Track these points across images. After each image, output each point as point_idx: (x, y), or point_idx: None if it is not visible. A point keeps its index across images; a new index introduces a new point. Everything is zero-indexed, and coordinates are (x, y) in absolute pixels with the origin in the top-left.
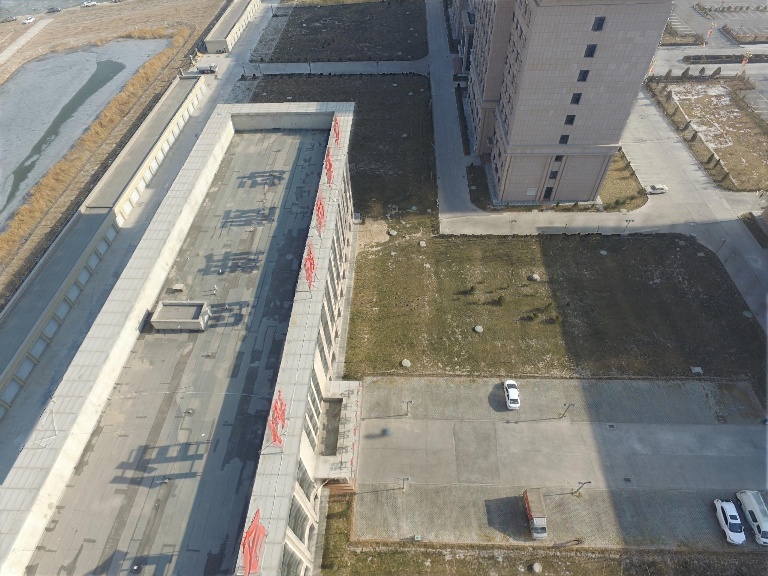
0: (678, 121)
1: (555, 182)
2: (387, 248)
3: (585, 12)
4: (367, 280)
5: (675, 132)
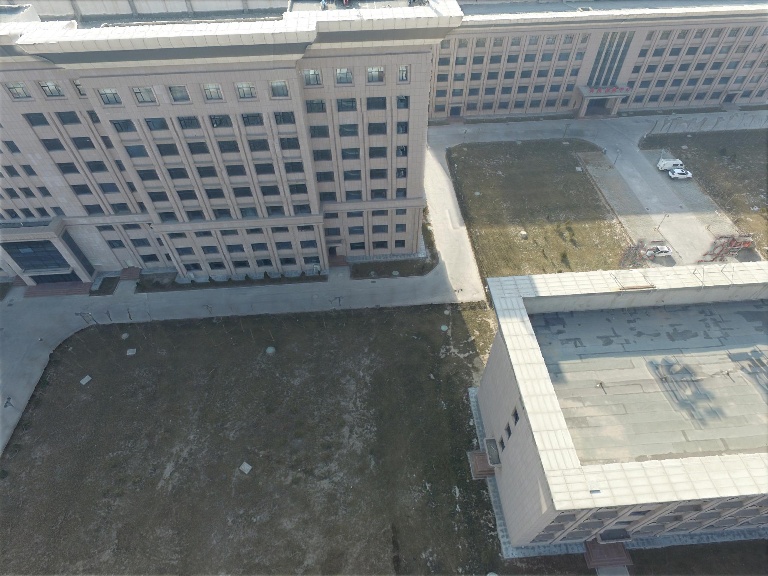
0: None
1: None
2: None
3: None
4: None
5: None
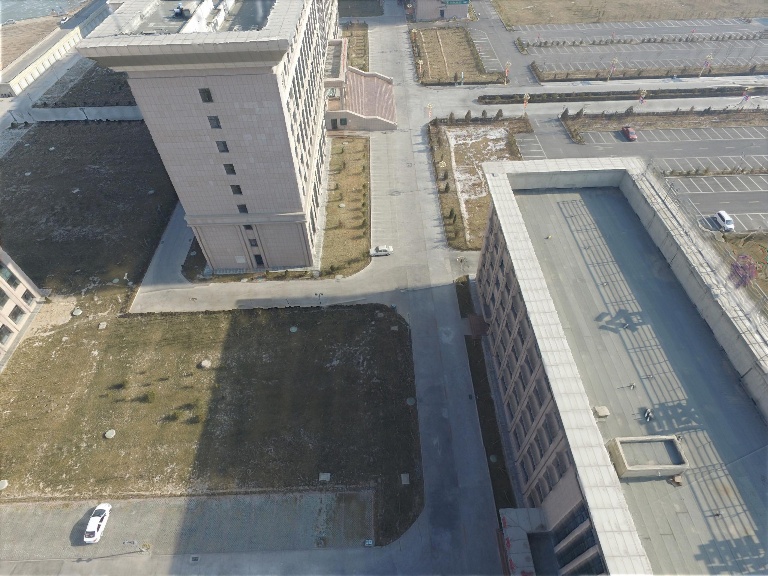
0: (443, 169)
1: (259, 250)
2: (61, 332)
3: (184, 84)
4: (17, 374)
5: (434, 182)
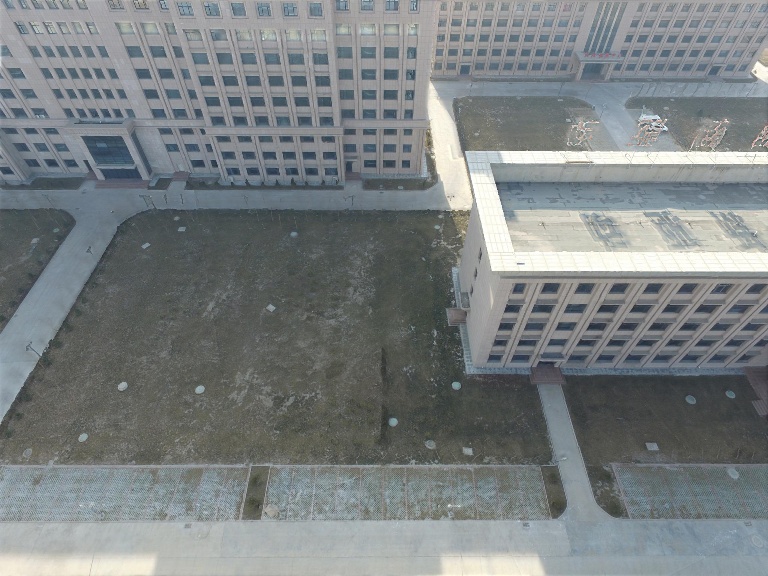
0: None
1: None
2: None
3: None
4: None
5: None
